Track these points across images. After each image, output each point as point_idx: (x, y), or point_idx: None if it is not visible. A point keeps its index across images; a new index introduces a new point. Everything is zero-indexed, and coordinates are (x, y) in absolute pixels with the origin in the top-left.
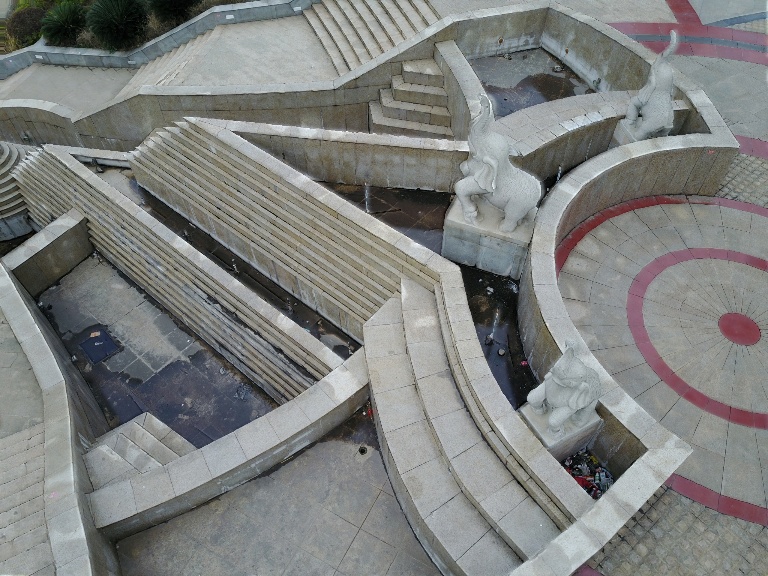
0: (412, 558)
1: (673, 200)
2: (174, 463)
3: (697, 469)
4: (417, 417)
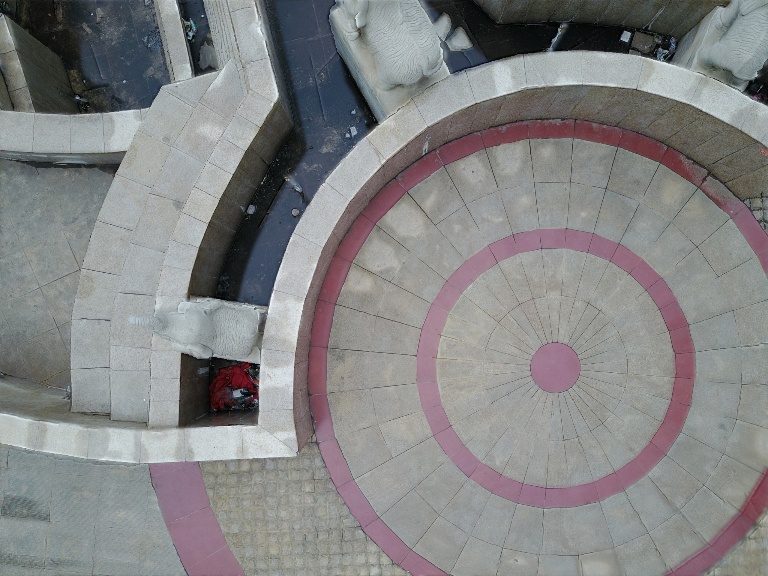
0: None
1: (684, 169)
2: None
3: (357, 448)
4: None
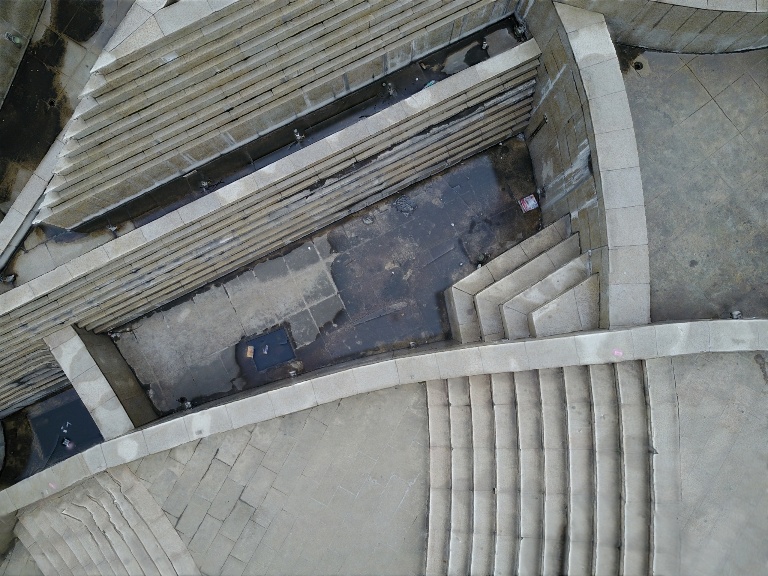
0: (759, 63)
1: None
2: (611, 239)
3: None
4: None
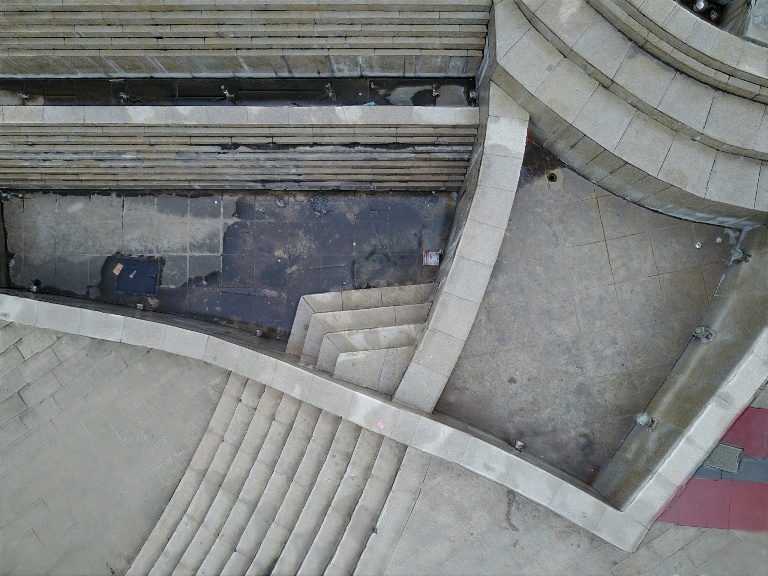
0: (663, 229)
1: None
2: (435, 320)
3: None
4: (628, 114)
